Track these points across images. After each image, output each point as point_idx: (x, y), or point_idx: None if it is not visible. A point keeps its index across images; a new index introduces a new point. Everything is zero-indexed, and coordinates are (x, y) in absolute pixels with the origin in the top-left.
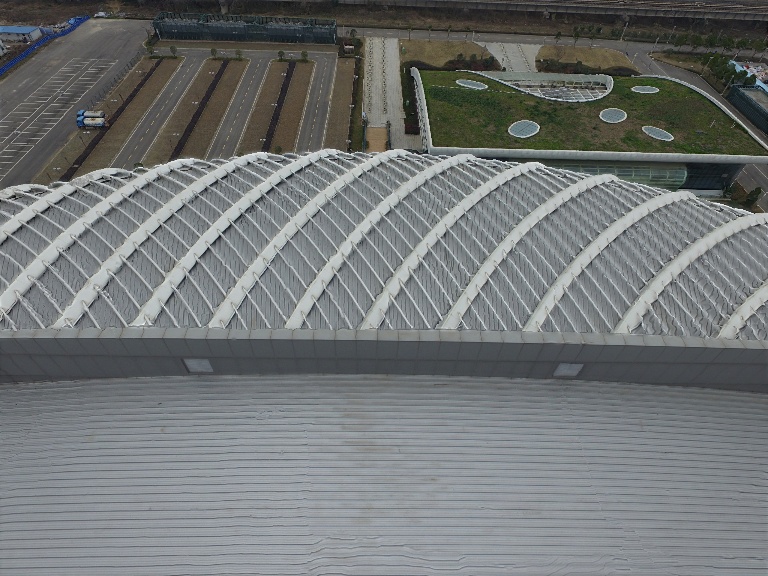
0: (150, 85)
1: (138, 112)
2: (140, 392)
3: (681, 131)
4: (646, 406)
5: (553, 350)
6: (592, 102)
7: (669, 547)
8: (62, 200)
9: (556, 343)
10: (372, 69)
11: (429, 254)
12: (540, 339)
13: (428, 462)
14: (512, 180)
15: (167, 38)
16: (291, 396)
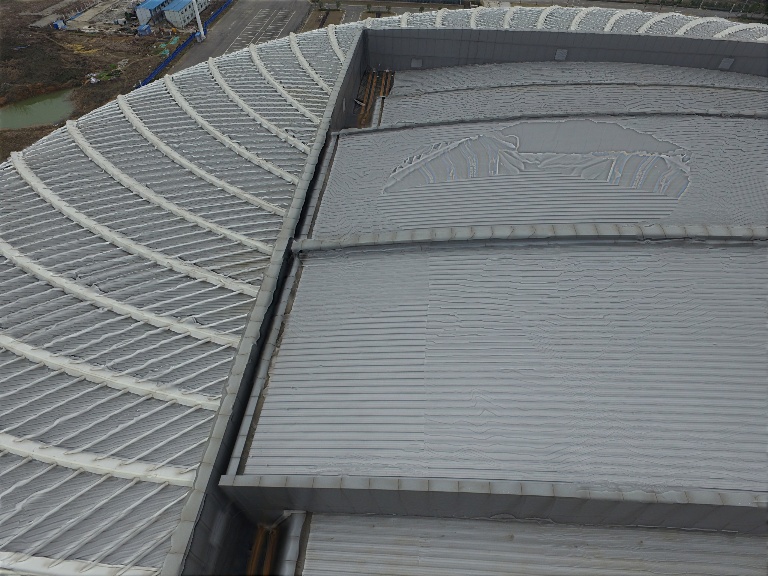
0: None
1: None
2: (534, 65)
3: None
4: None
5: (723, 46)
6: None
7: None
8: None
9: (726, 40)
10: None
11: None
12: (719, 38)
13: None
14: None
15: None
16: (602, 68)
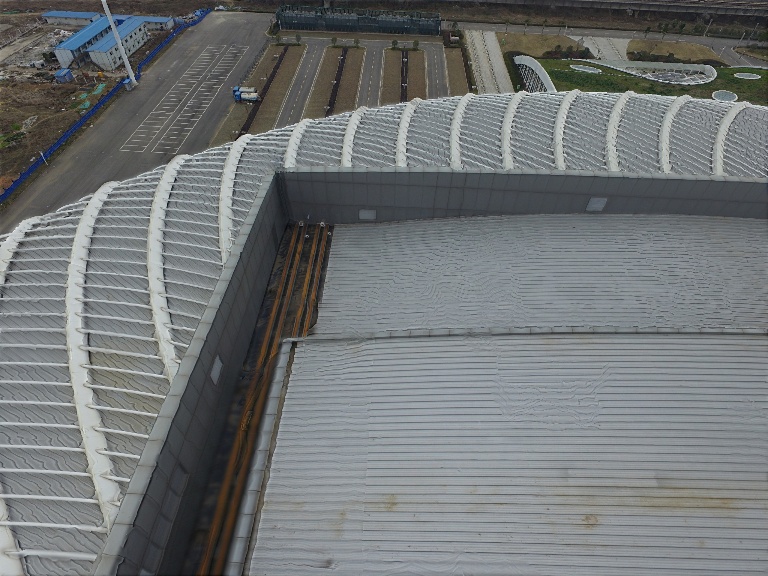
0: (284, 68)
1: (281, 90)
2: (554, 222)
3: None
4: None
5: None
6: (702, 85)
7: None
8: (414, 113)
9: None
10: (478, 58)
11: (726, 145)
12: None
13: None
14: None
15: (286, 28)
16: (662, 226)
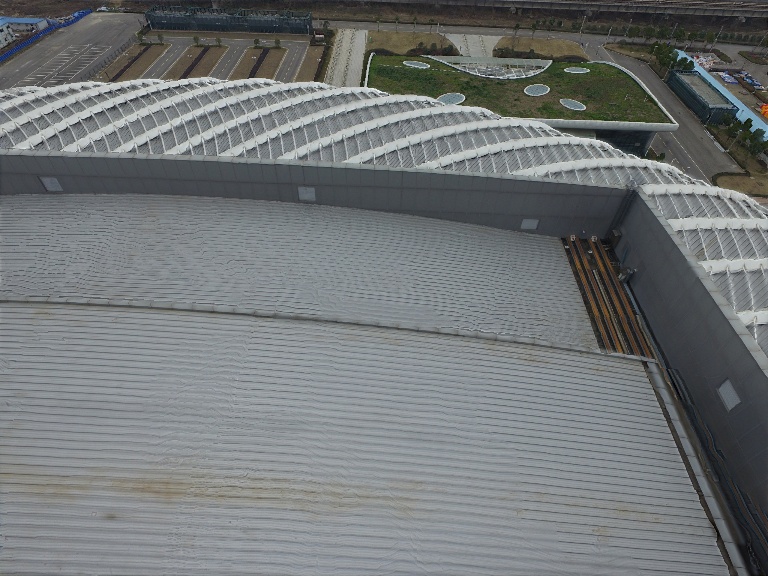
0: (136, 67)
1: None
2: (12, 202)
3: (596, 103)
4: (361, 220)
5: (284, 172)
6: (522, 79)
7: (325, 281)
8: None
9: (283, 165)
10: (338, 55)
11: (236, 127)
12: (272, 162)
13: (195, 245)
14: (339, 95)
15: (158, 28)
16: (112, 205)
